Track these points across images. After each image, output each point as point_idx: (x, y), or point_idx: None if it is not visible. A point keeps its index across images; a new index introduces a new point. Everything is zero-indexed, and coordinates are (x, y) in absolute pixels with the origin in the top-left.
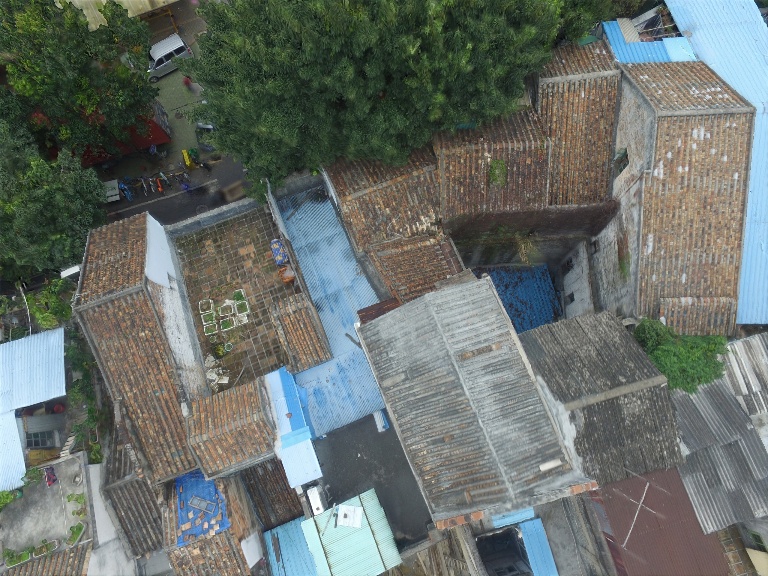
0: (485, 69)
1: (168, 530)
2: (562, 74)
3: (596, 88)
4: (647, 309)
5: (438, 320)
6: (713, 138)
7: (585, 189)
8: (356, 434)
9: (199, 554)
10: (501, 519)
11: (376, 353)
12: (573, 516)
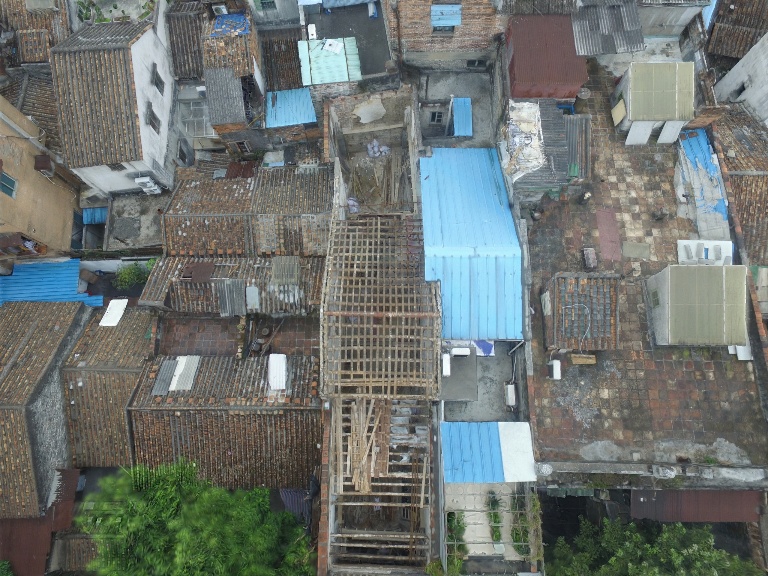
0: None
1: (206, 30)
2: None
3: None
4: None
5: None
6: None
7: None
8: (352, 18)
9: (223, 47)
10: (437, 20)
11: None
12: (494, 95)
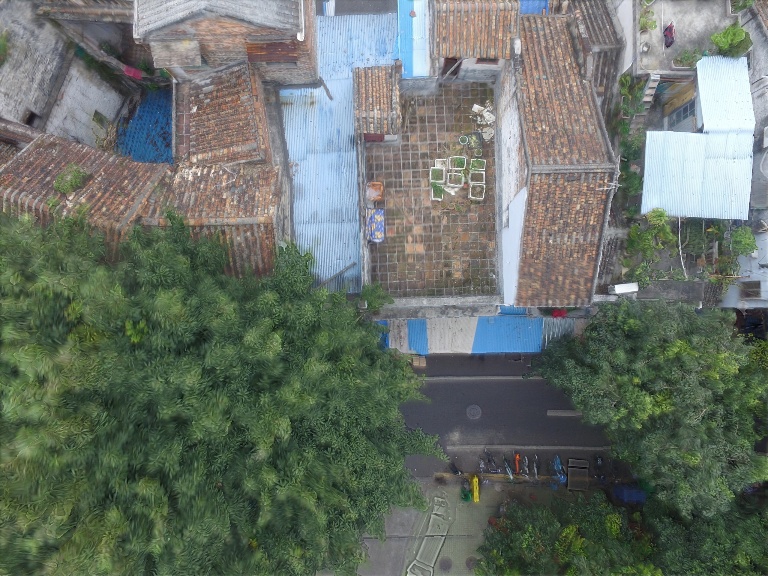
0: None
1: None
2: None
3: None
4: None
5: None
6: None
7: None
8: (359, 9)
9: None
10: None
11: None
12: None
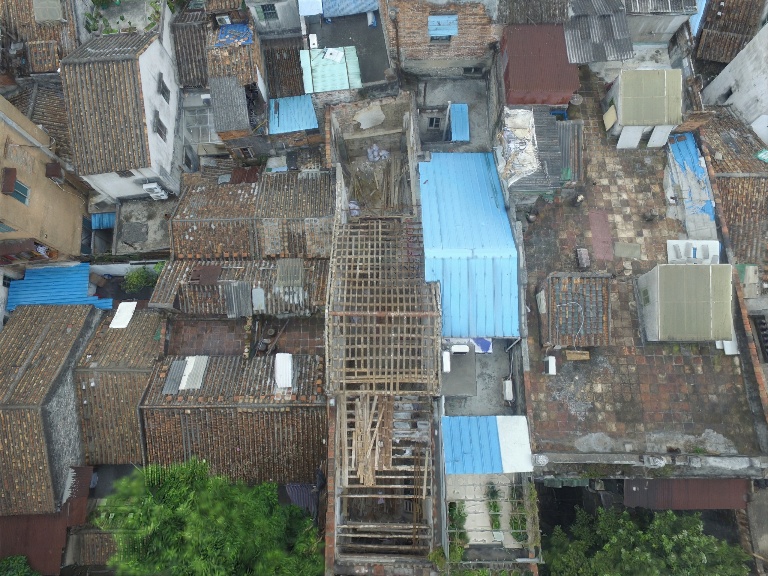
0: None
1: (210, 40)
2: None
3: None
4: None
5: None
6: None
7: None
8: (352, 27)
9: (227, 56)
10: (434, 30)
11: None
12: (490, 101)
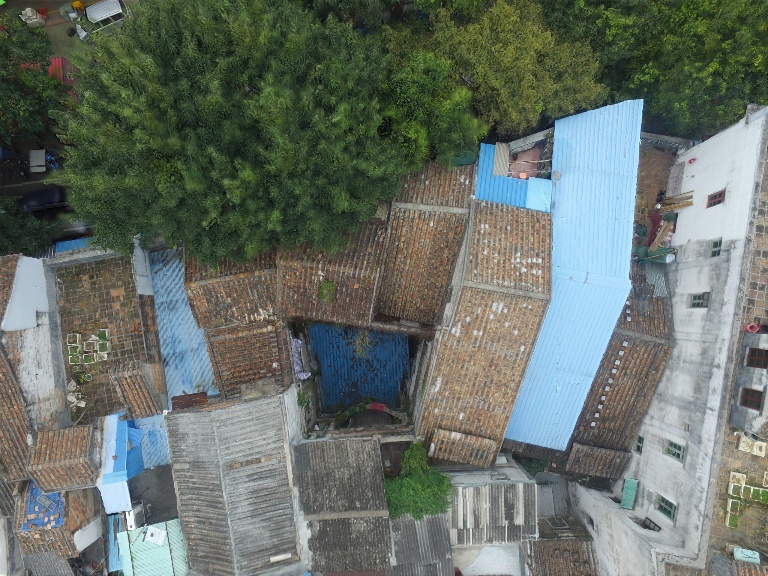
0: (306, 219)
1: (18, 516)
2: (417, 200)
3: (444, 221)
4: (425, 432)
5: (217, 435)
6: (509, 313)
7: (422, 303)
8: None
9: (39, 538)
10: None
11: (174, 441)
12: None
